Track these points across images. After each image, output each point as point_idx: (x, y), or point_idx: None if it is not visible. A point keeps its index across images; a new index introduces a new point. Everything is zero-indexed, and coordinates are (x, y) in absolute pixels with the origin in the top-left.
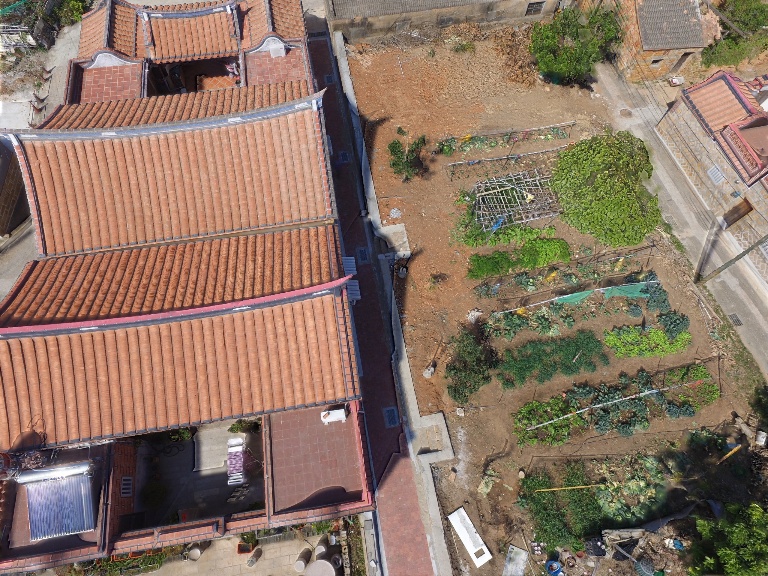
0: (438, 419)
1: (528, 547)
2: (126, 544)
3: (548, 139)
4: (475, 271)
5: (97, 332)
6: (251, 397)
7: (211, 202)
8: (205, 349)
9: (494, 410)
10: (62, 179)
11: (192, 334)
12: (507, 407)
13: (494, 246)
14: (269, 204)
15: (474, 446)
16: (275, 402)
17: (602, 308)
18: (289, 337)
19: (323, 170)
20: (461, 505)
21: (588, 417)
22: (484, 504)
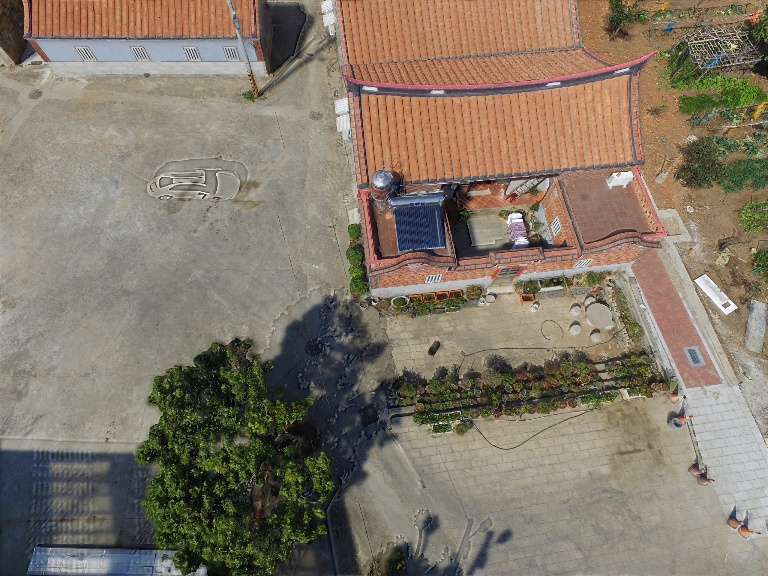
0: (673, 213)
1: (767, 301)
2: (468, 262)
3: (728, 14)
4: (685, 108)
5: (440, 98)
6: (559, 157)
7: (480, 30)
8: (521, 118)
9: (719, 208)
10: (362, 3)
11: (511, 106)
12: (730, 206)
13: (697, 91)
14: (527, 34)
15: (706, 233)
16: (578, 162)
17: None
18: (589, 111)
19: (573, 7)
20: (703, 273)
21: None
22: (724, 272)
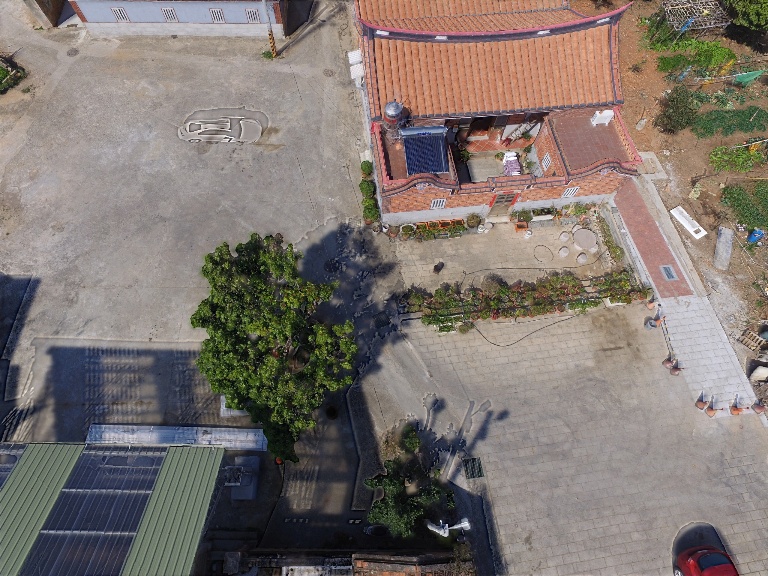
0: (652, 155)
1: (733, 227)
2: (469, 186)
3: None
4: (663, 66)
5: (444, 43)
6: (548, 97)
7: None
8: (515, 62)
9: (692, 151)
10: None
11: (506, 52)
12: (702, 149)
13: (674, 52)
14: None
15: (681, 172)
16: (565, 101)
17: (764, 93)
18: (575, 57)
19: None
20: (678, 205)
21: (764, 157)
22: (695, 204)
